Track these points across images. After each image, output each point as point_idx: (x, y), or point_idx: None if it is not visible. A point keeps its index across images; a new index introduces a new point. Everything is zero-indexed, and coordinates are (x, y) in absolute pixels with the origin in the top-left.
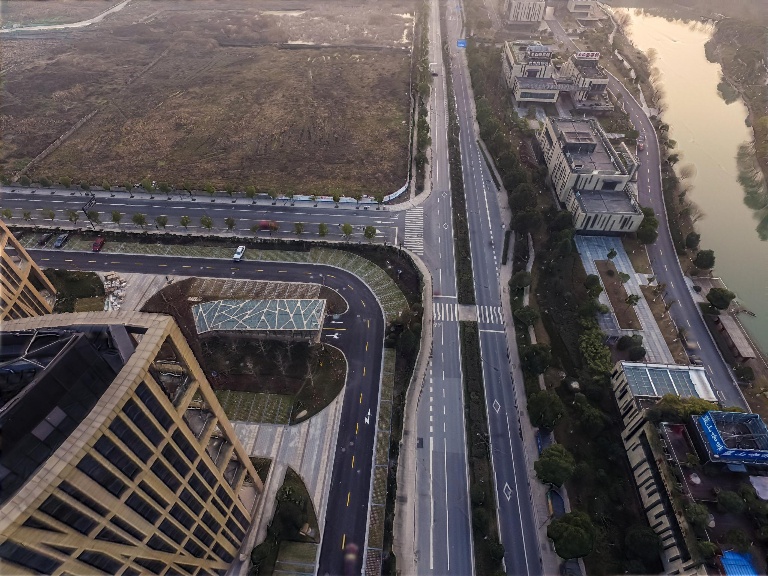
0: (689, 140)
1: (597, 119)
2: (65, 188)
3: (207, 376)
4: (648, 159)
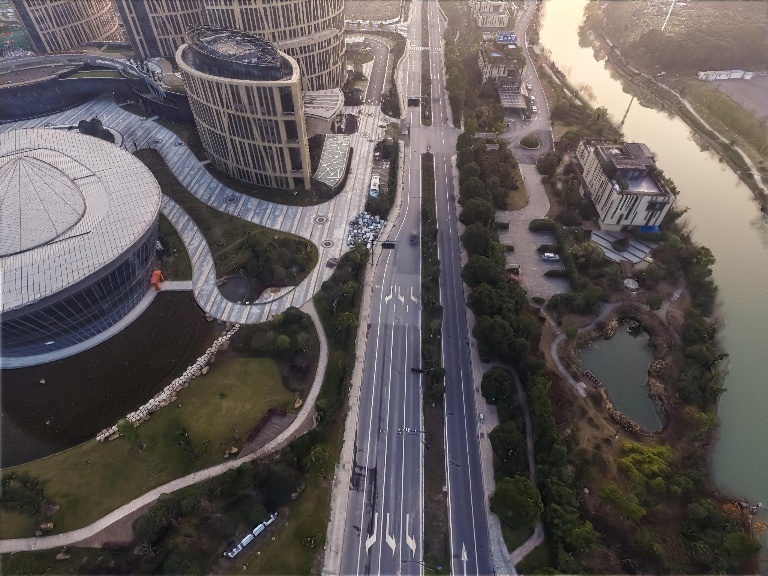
0: (556, 11)
1: (507, 1)
2: None
3: None
4: (528, 14)
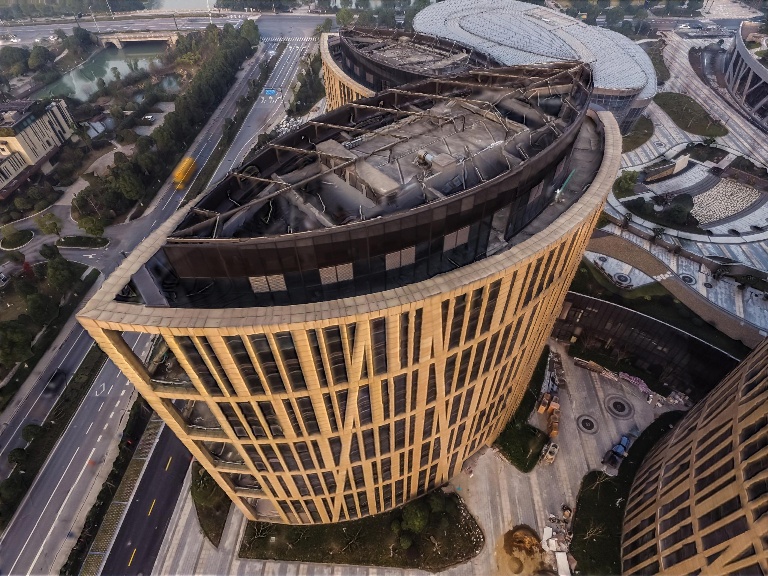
0: None
1: None
2: None
3: None
4: None
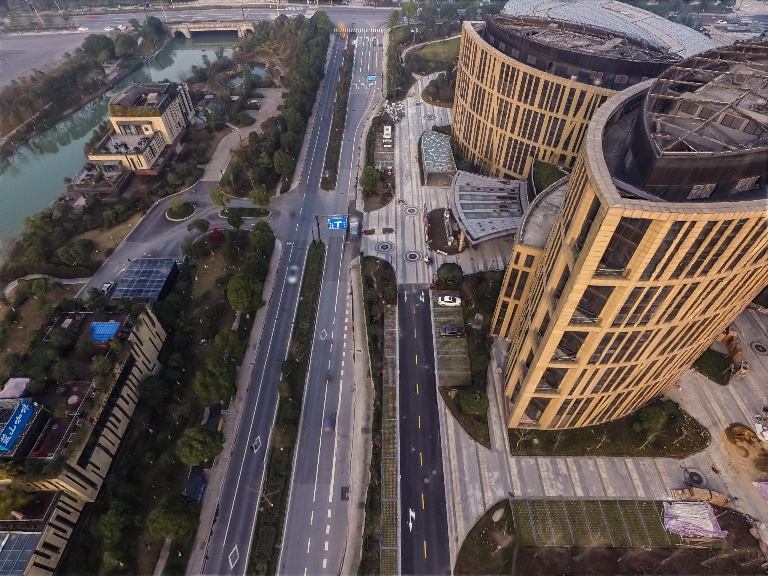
0: None
1: None
2: None
3: (663, 570)
4: None
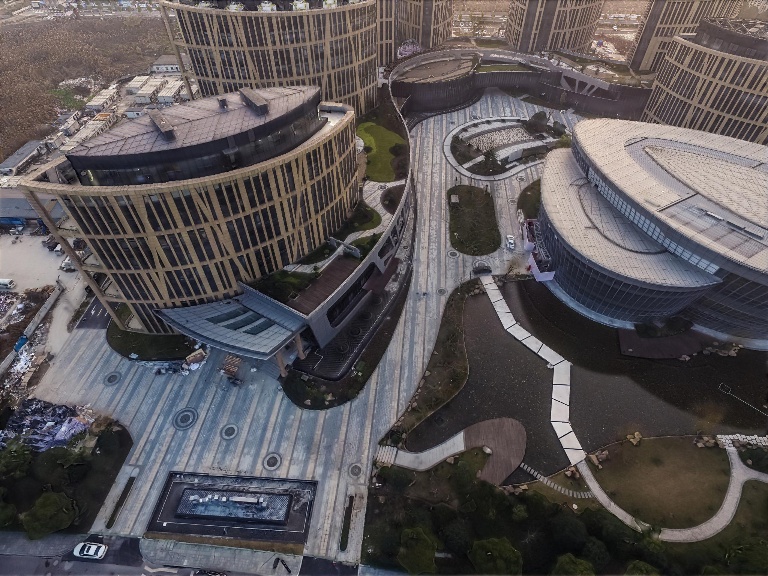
0: None
1: None
2: (496, 14)
3: None
4: None
